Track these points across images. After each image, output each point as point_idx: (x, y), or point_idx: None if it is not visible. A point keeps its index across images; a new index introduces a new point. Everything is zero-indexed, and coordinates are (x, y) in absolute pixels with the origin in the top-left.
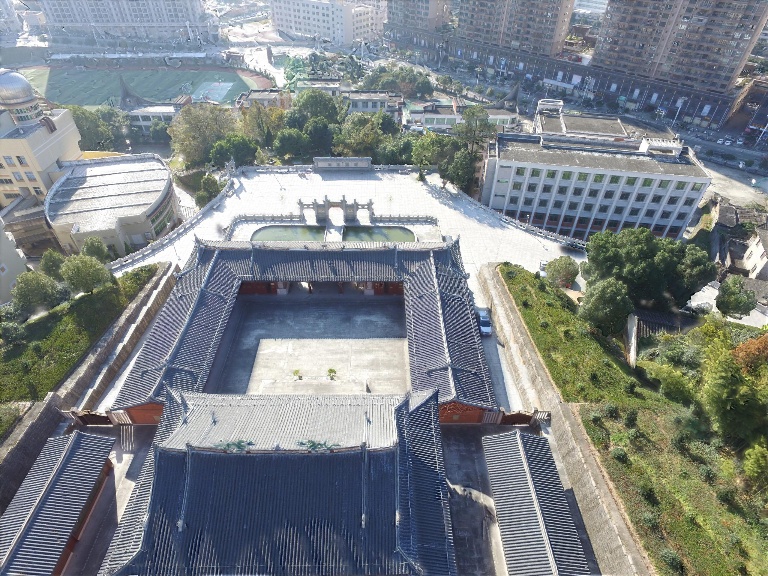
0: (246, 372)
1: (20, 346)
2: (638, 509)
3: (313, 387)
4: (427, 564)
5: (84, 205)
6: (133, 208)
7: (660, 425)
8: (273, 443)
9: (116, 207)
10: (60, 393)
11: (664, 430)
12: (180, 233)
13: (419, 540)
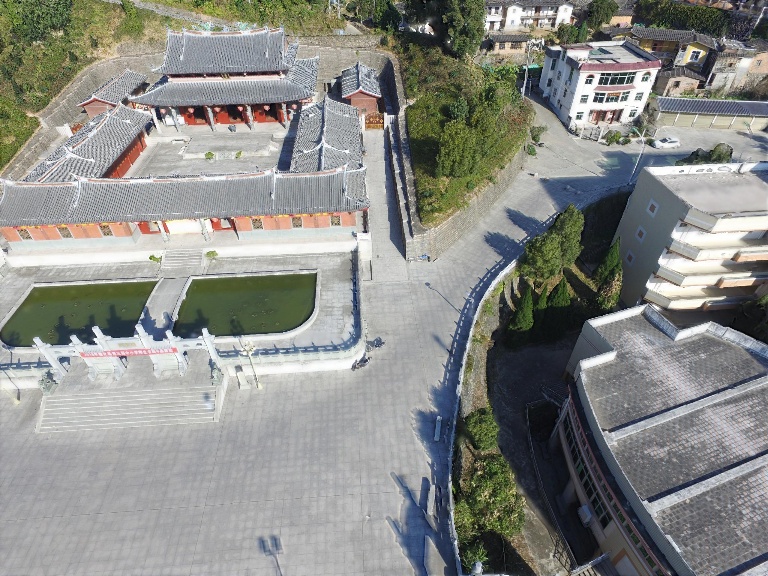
0: (284, 160)
1: (451, 117)
2: (62, 79)
3: (227, 149)
4: None
5: (765, 411)
6: (637, 408)
7: (2, 90)
8: (231, 41)
9: (679, 407)
10: (402, 117)
11: (3, 88)
12: (467, 338)
13: None
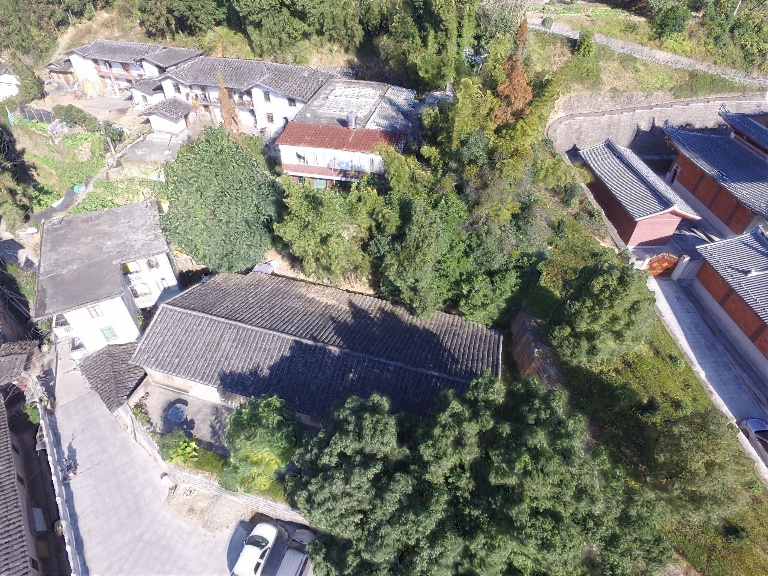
0: None
1: None
2: None
3: None
4: (707, 145)
5: None
6: None
7: None
8: None
9: None
10: None
11: None
12: None
13: (720, 150)
